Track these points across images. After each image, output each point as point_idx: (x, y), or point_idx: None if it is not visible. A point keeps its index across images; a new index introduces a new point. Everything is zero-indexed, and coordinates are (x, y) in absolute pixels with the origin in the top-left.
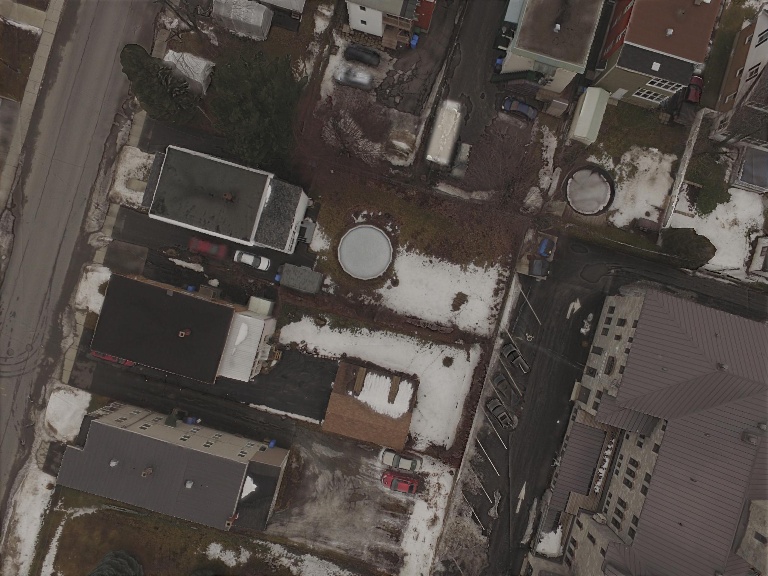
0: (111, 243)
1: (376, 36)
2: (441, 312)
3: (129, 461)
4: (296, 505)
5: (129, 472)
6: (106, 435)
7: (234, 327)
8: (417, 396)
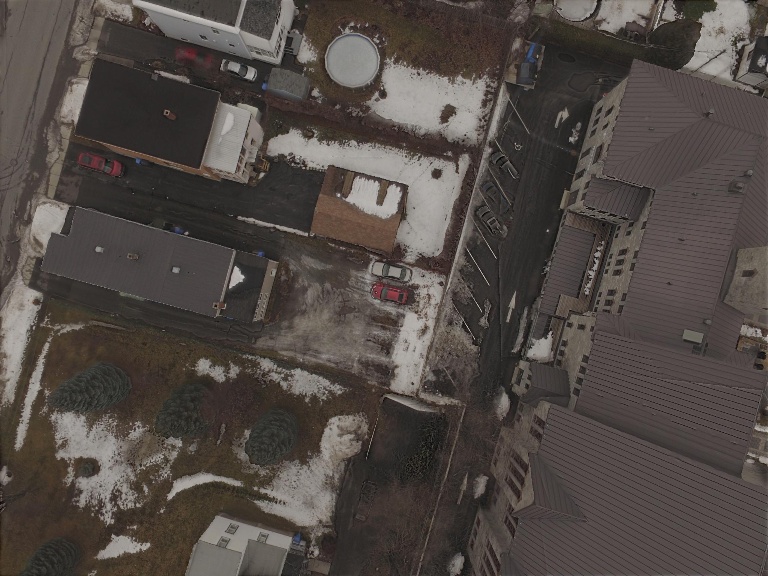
0: (96, 56)
1: None
2: (429, 124)
3: (115, 249)
4: (285, 318)
5: (115, 260)
6: (91, 222)
7: (220, 116)
8: (406, 208)
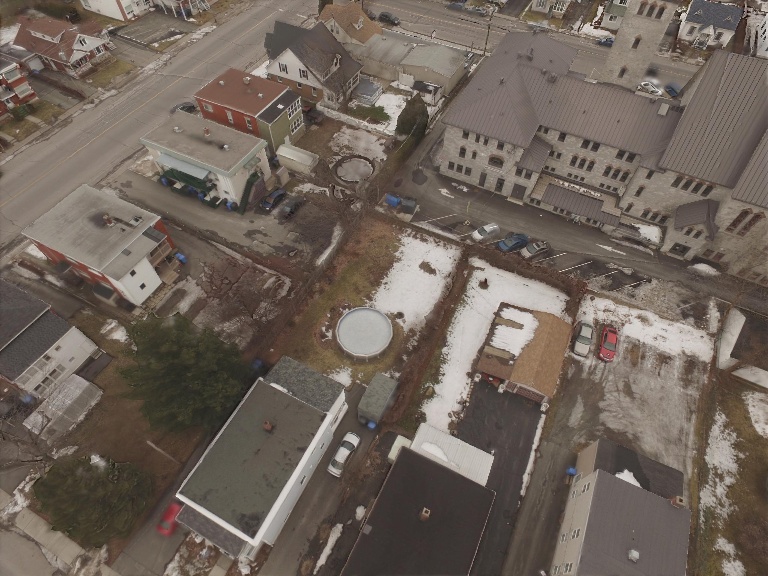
0: None
1: (159, 287)
2: (435, 283)
3: None
4: None
5: None
6: None
7: None
8: None
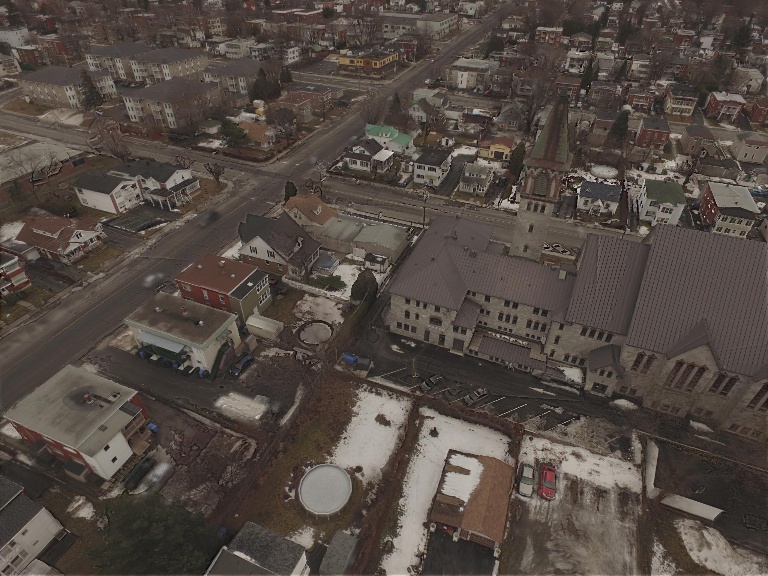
0: None
1: (129, 459)
2: (390, 435)
3: None
4: None
5: None
6: None
7: None
8: None
